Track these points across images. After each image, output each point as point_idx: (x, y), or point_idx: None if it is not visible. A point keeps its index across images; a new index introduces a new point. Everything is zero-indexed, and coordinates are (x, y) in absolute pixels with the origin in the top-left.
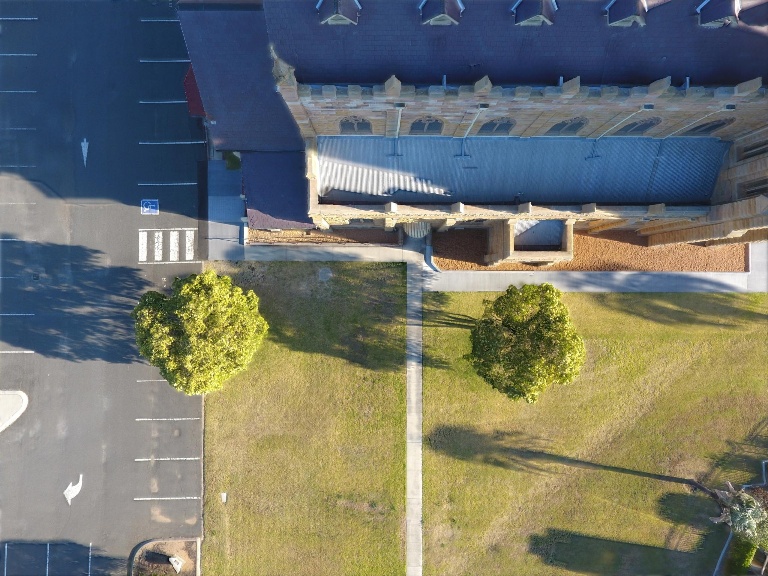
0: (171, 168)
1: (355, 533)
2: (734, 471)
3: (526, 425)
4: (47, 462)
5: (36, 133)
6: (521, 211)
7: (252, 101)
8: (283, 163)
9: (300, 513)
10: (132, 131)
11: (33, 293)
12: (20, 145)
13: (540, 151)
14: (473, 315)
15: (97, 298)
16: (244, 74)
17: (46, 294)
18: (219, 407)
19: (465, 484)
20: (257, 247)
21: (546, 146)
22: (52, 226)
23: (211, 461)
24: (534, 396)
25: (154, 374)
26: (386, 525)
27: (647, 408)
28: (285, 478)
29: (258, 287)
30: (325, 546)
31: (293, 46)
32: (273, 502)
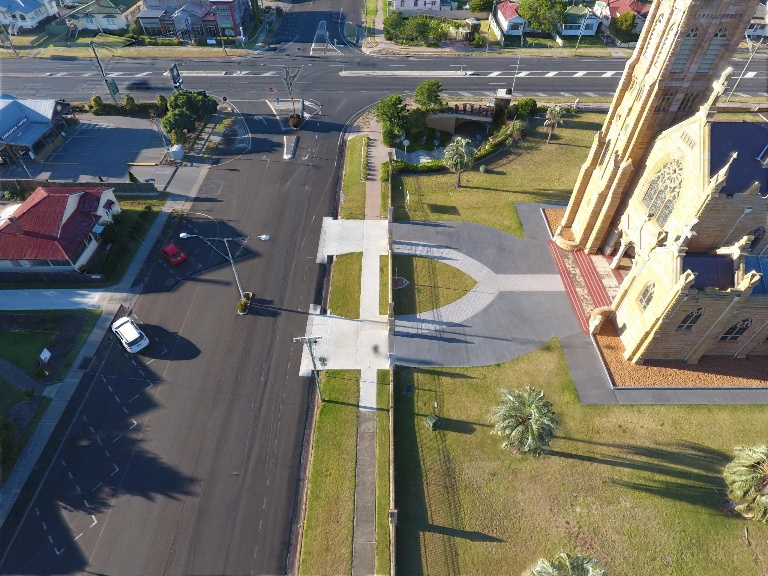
0: None
1: None
2: (528, 146)
3: None
4: None
5: None
6: None
7: None
8: None
9: None
10: None
11: None
12: None
13: None
14: None
15: None
16: None
17: None
18: None
19: None
20: None
21: None
22: None
23: None
24: None
25: None
26: None
27: None
28: None
29: None
30: None
31: None
32: None
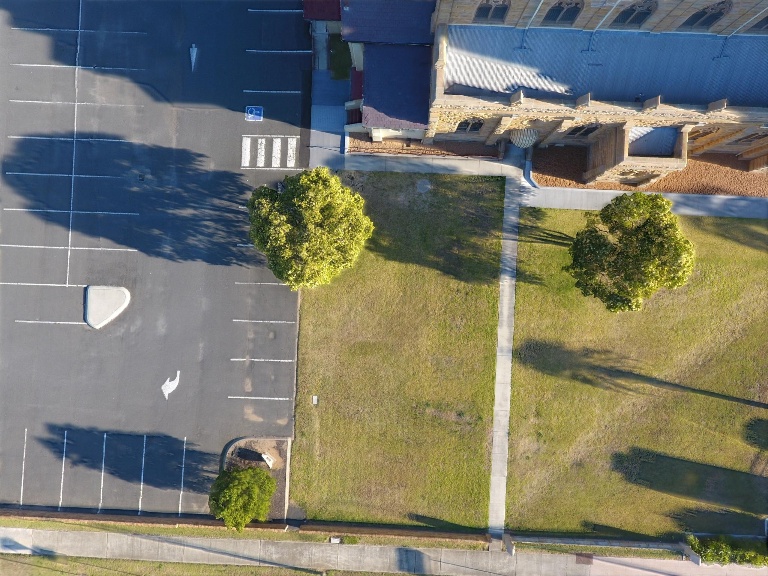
0: (276, 76)
1: (442, 441)
2: None
3: (616, 344)
4: (146, 357)
5: (146, 37)
6: (648, 106)
7: None
8: (404, 58)
9: (389, 419)
10: (240, 38)
11: (138, 193)
12: (131, 48)
13: (668, 49)
14: (568, 233)
15: (200, 201)
16: None
17: (151, 195)
18: (314, 312)
19: (553, 399)
20: (357, 157)
21: (675, 43)
22: (159, 129)
23: (304, 364)
24: (639, 303)
25: (252, 277)
26: (473, 435)
27: (739, 334)
28: (376, 384)
29: None
30: (412, 452)
31: None
32: (363, 407)
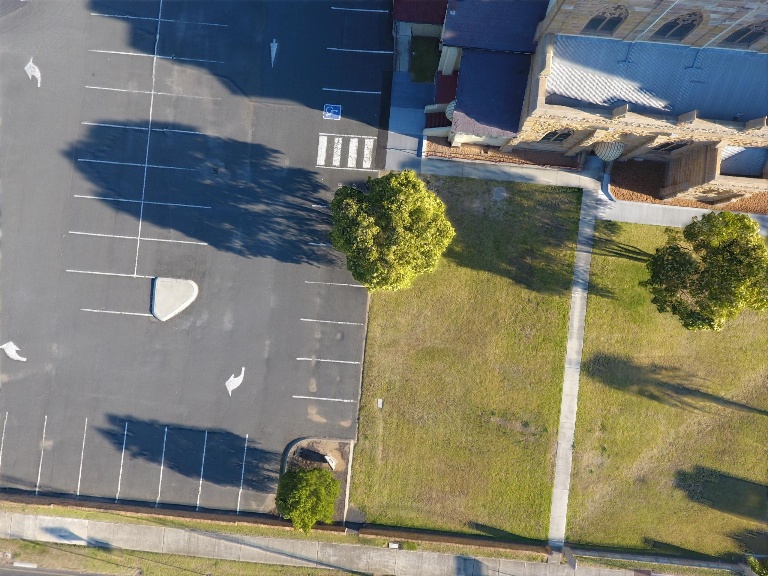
0: (356, 75)
1: (506, 451)
2: None
3: (684, 362)
4: (212, 352)
5: (227, 30)
6: (752, 126)
7: None
8: (502, 65)
9: (453, 426)
10: (321, 35)
11: (211, 186)
12: (211, 40)
13: None
14: (643, 248)
15: (273, 197)
16: None
17: (224, 189)
18: (383, 315)
19: (619, 414)
20: (434, 161)
21: None
22: (235, 123)
23: (371, 367)
24: (721, 323)
25: (322, 276)
26: (537, 446)
27: None
28: (442, 390)
29: None
30: (475, 461)
31: None
32: (428, 413)
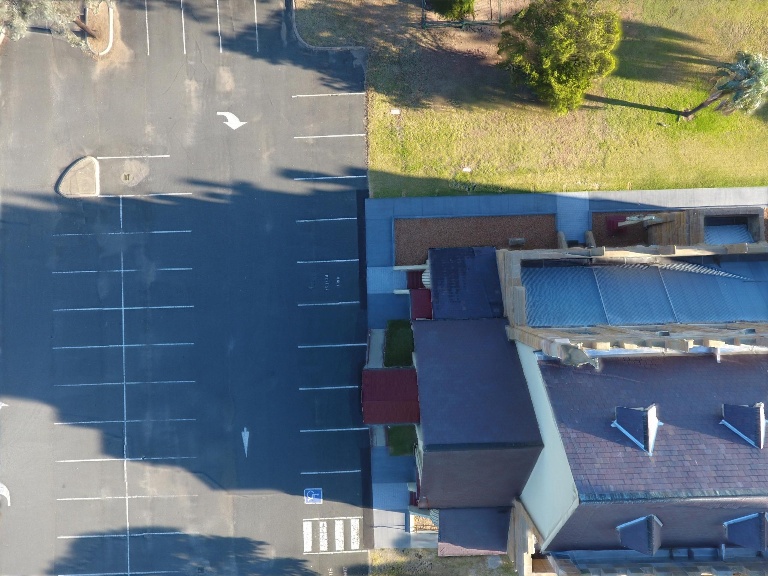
0: (333, 456)
1: None
2: None
3: None
4: None
5: (196, 423)
6: None
7: (472, 487)
8: (482, 508)
9: None
10: (293, 419)
11: None
12: (180, 436)
13: None
14: None
15: None
16: (472, 476)
17: None
18: None
19: None
20: (424, 534)
21: None
22: (215, 518)
23: None
24: None
25: None
26: None
27: None
28: None
29: (426, 575)
30: None
31: (577, 540)
32: None
